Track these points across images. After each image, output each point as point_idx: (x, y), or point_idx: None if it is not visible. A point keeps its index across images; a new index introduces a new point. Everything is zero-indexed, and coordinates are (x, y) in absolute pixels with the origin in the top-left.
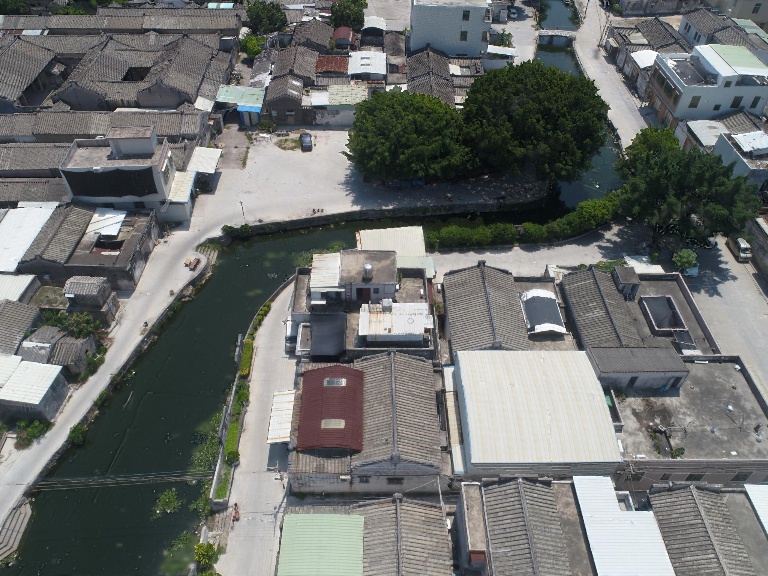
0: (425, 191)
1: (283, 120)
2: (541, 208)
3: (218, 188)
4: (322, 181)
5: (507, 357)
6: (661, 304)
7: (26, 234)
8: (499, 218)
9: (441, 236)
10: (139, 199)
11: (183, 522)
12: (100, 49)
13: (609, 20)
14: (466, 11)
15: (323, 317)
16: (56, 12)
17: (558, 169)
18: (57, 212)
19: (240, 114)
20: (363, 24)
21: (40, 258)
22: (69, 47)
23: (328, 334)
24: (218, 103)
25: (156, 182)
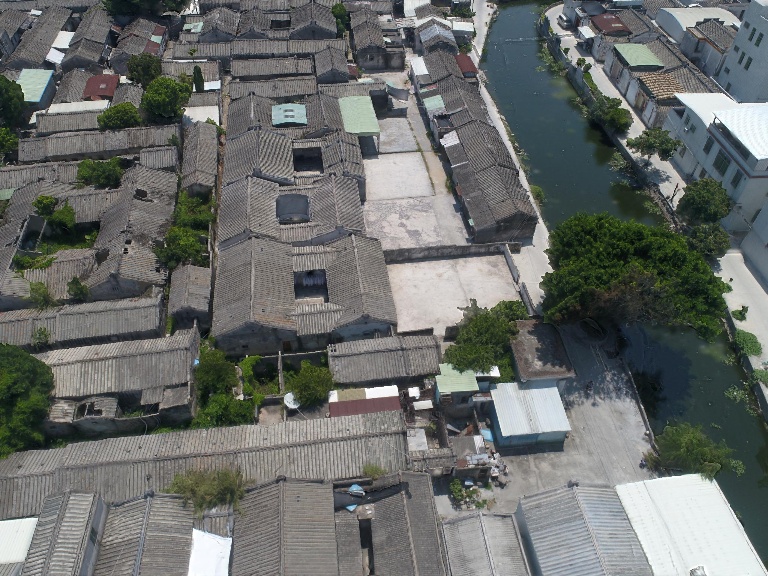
0: None
1: None
2: None
3: None
4: None
5: (683, 8)
6: (745, 1)
7: None
8: None
9: None
10: None
11: (552, 73)
12: None
13: None
14: None
15: (588, 3)
16: None
17: None
18: None
19: None
20: None
21: None
22: None
23: (593, 9)
24: None
25: None
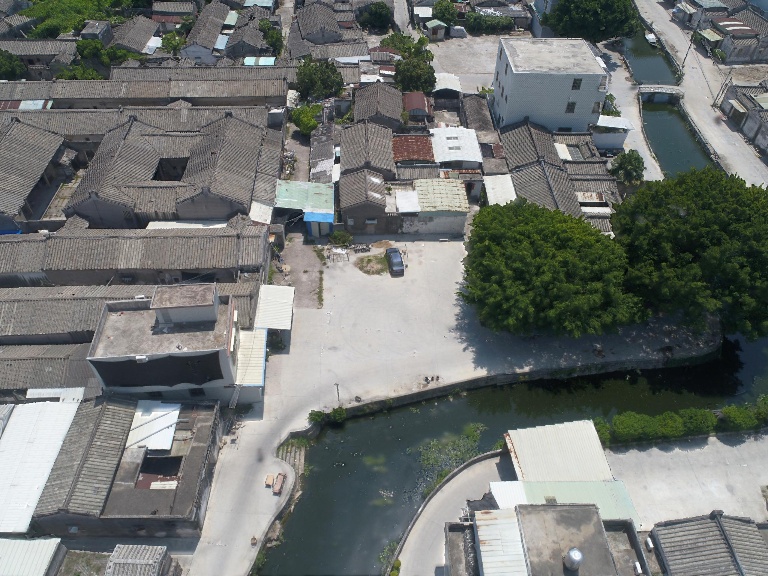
0: (565, 340)
1: (360, 229)
2: (717, 360)
3: (292, 342)
4: (427, 326)
5: None
6: None
7: (41, 454)
8: (667, 378)
9: (617, 431)
10: (197, 386)
11: None
12: (123, 137)
13: (712, 69)
14: (577, 79)
15: None
16: (60, 74)
17: (766, 329)
18: (83, 412)
19: (307, 224)
20: (434, 84)
21: (65, 512)
22: (80, 126)
23: None
24: (278, 209)
25: (222, 367)
